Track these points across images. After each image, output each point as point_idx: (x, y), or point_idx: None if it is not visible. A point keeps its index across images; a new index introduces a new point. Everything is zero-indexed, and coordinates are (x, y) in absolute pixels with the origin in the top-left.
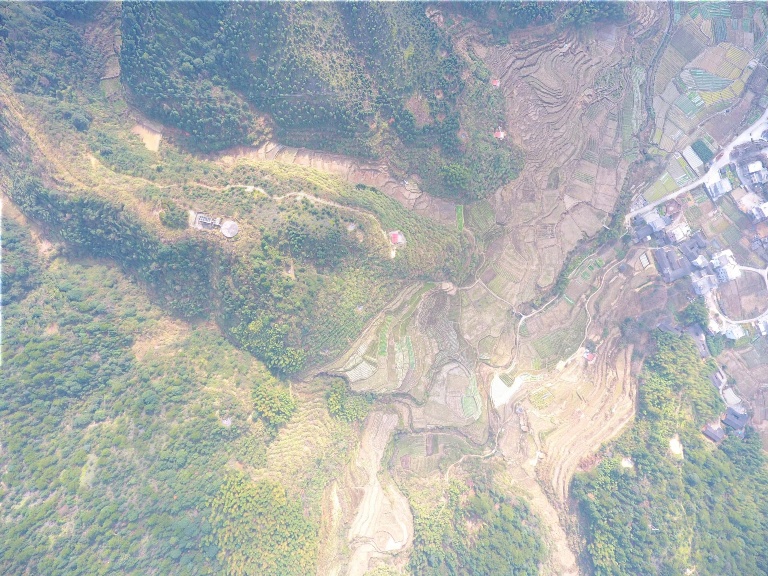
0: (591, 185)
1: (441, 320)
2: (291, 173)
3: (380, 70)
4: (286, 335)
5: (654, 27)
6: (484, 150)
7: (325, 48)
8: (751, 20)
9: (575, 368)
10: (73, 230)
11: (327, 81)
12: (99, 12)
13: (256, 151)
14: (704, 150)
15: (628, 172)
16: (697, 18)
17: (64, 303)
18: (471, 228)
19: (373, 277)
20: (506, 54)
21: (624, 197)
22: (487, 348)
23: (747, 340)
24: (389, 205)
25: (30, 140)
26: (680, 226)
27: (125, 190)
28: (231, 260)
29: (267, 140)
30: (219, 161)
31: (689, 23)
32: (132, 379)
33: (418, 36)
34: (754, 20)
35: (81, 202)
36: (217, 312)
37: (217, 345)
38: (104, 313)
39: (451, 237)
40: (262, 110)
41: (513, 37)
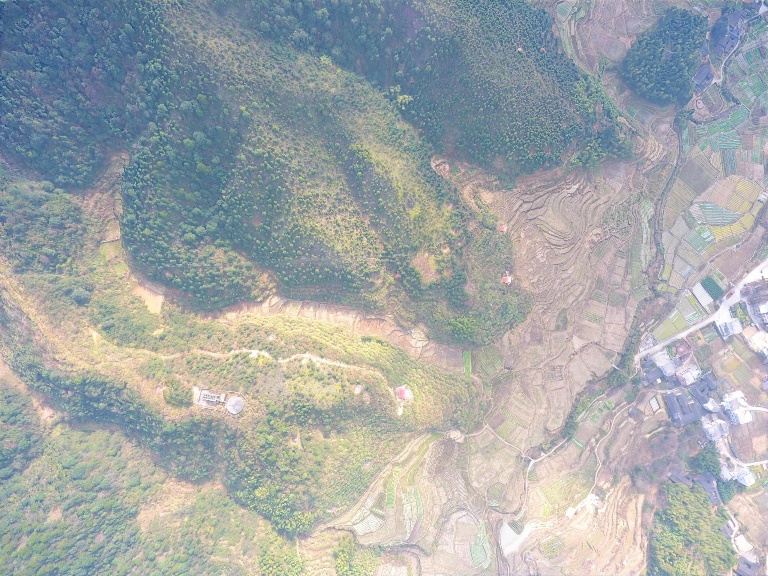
0: (600, 325)
1: (449, 468)
2: (296, 331)
3: (385, 228)
4: (293, 503)
5: (663, 161)
6: (491, 300)
7: (329, 213)
8: (761, 151)
9: (585, 516)
10: (75, 404)
11: (332, 247)
12: (98, 179)
13: (260, 306)
14: (714, 288)
15: (637, 310)
16: (706, 150)
17: (67, 483)
18: (479, 375)
19: (380, 433)
20: (513, 198)
21: (633, 335)
22: (496, 495)
23: (759, 483)
24: (396, 357)
25: (30, 321)
26: (690, 370)
27: (128, 367)
28: (236, 434)
29: (271, 294)
30: (222, 318)
31: (698, 155)
32: (137, 556)
33: (424, 194)
34: (764, 151)
35: (83, 381)
36: (222, 474)
37: (223, 507)
38: (108, 488)
39: (459, 387)
40: (266, 267)
41: (520, 182)
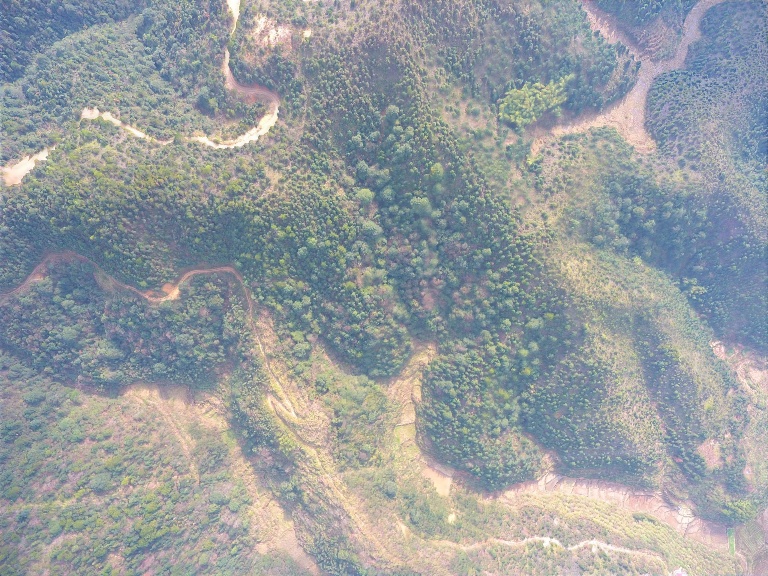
0: None
1: None
2: (578, 513)
3: (673, 415)
4: None
5: None
6: (763, 481)
7: (630, 406)
8: None
9: None
10: None
11: (632, 441)
12: (403, 368)
13: (536, 483)
14: None
15: None
16: None
17: None
18: (742, 552)
19: None
20: None
21: None
22: None
23: None
24: (668, 537)
25: (349, 518)
26: None
27: (439, 564)
28: None
29: (547, 472)
30: (502, 497)
31: None
32: None
33: (715, 385)
34: None
35: None
36: None
37: None
38: None
39: (727, 567)
40: (549, 449)
41: None
